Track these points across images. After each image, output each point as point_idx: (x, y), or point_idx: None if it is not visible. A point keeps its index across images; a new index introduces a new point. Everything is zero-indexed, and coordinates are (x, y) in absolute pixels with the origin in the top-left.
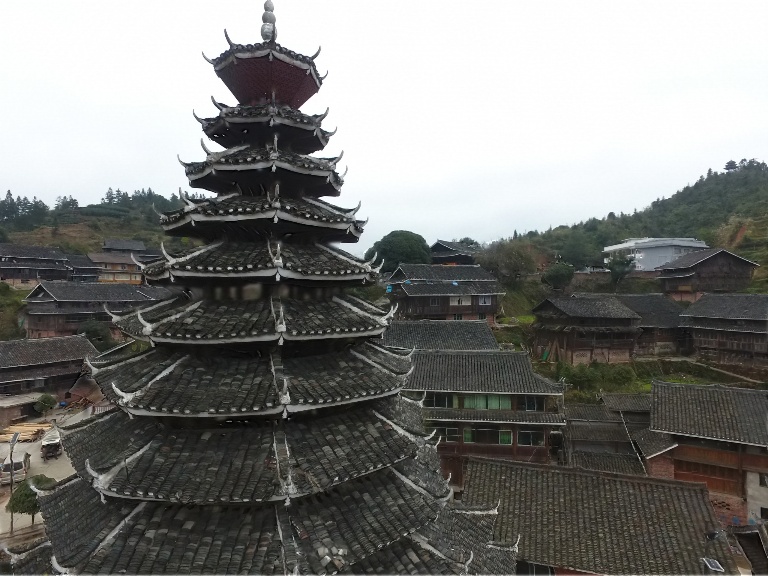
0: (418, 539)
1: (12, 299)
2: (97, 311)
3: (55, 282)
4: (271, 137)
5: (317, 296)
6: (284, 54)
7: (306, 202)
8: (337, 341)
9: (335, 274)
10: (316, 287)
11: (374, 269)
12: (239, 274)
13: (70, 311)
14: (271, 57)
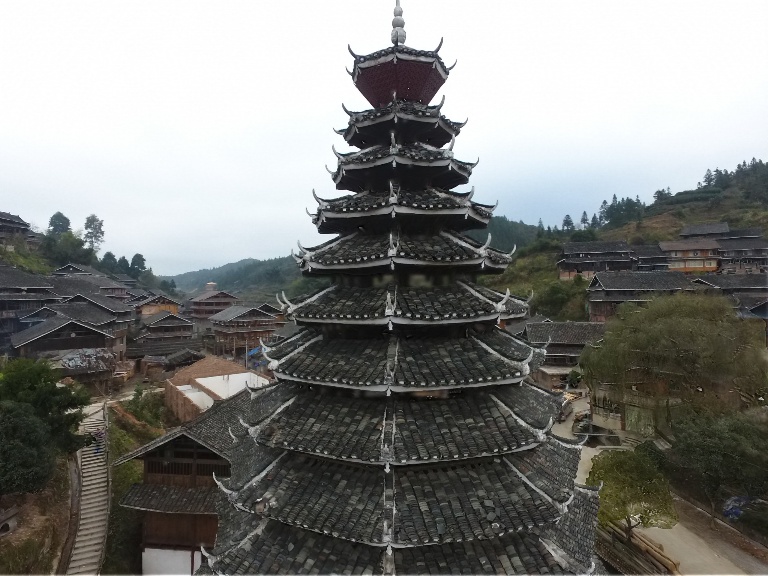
0: (384, 564)
1: (583, 288)
2: (641, 299)
3: (607, 273)
4: (376, 139)
5: (375, 283)
6: (368, 60)
7: (389, 191)
8: (356, 327)
9: (352, 262)
10: (363, 275)
11: (479, 249)
12: (305, 268)
13: (616, 299)
14: (359, 70)
